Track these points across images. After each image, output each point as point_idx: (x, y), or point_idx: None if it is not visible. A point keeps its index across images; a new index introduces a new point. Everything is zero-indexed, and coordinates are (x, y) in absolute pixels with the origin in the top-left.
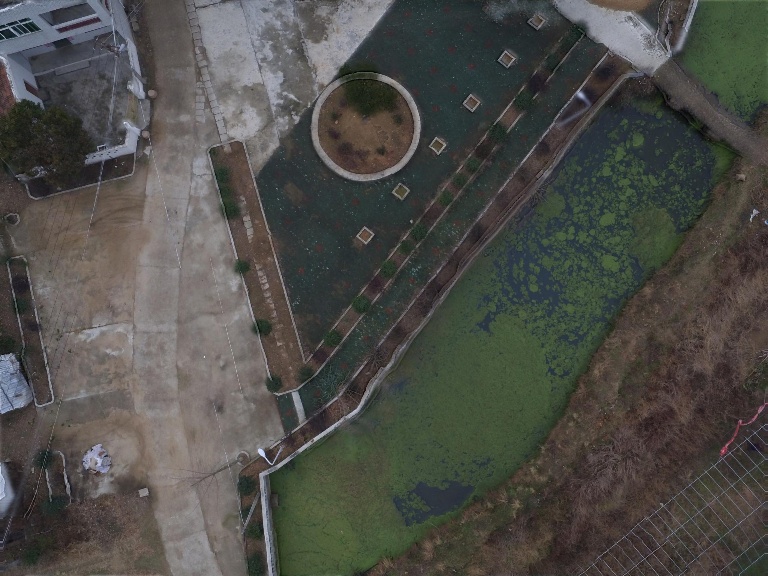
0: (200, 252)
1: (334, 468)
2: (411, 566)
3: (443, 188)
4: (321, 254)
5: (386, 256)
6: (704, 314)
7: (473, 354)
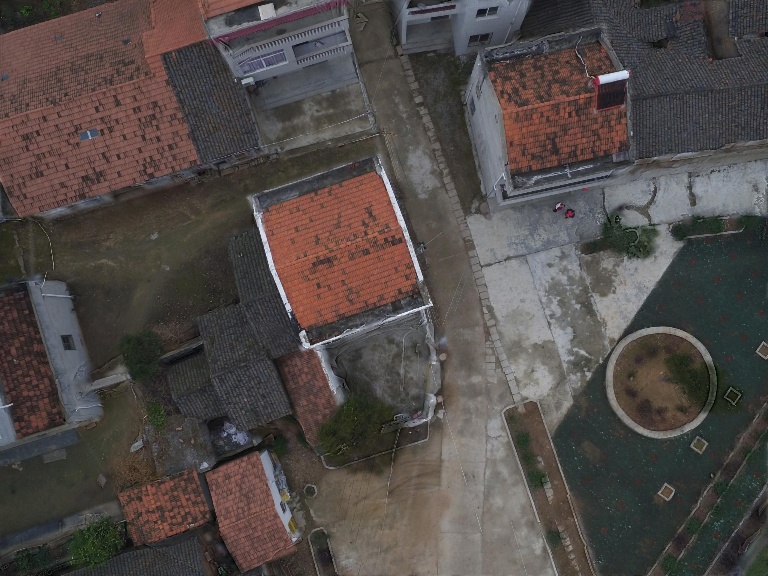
0: (500, 516)
1: None
2: None
3: (741, 439)
4: (622, 512)
5: (688, 512)
6: None
7: None
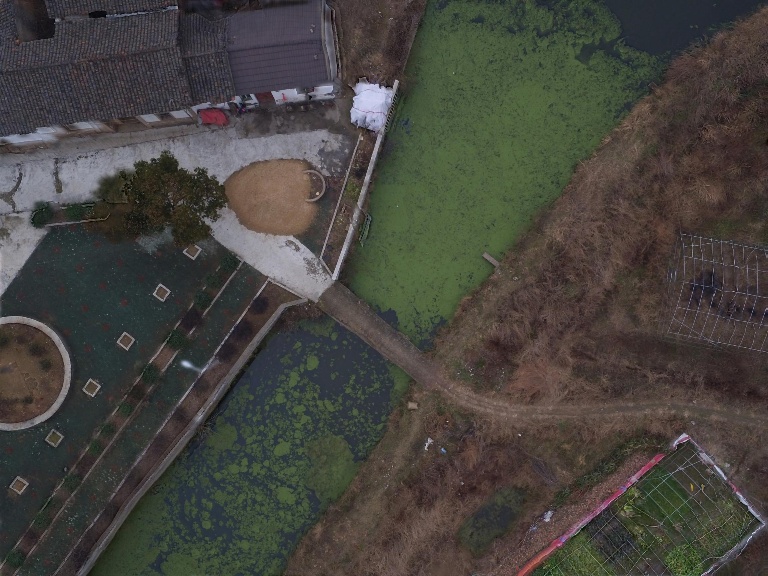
0: None
1: None
2: None
3: (98, 432)
4: None
5: (40, 506)
6: (377, 551)
7: None
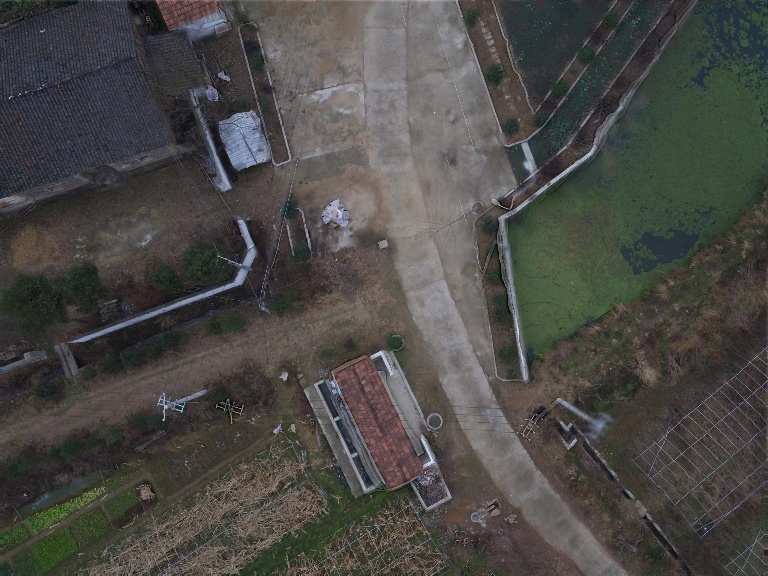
0: (425, 12)
1: (561, 221)
2: (645, 308)
3: None
4: (543, 9)
5: (607, 9)
6: None
7: (689, 108)
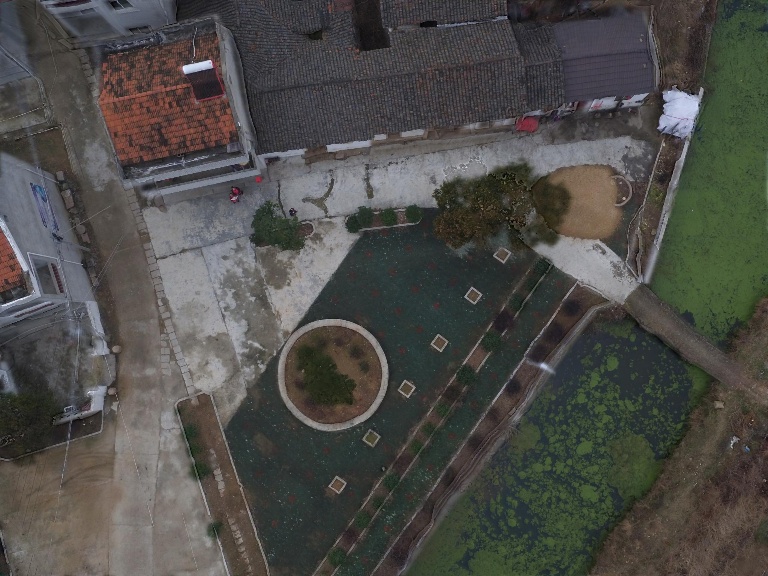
0: (172, 508)
1: None
2: None
3: (414, 432)
4: (294, 505)
5: (359, 505)
6: (687, 547)
7: None
